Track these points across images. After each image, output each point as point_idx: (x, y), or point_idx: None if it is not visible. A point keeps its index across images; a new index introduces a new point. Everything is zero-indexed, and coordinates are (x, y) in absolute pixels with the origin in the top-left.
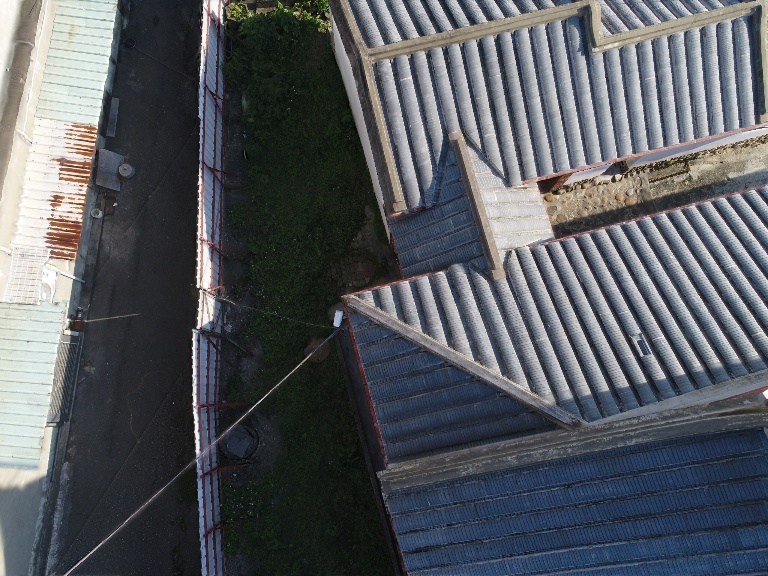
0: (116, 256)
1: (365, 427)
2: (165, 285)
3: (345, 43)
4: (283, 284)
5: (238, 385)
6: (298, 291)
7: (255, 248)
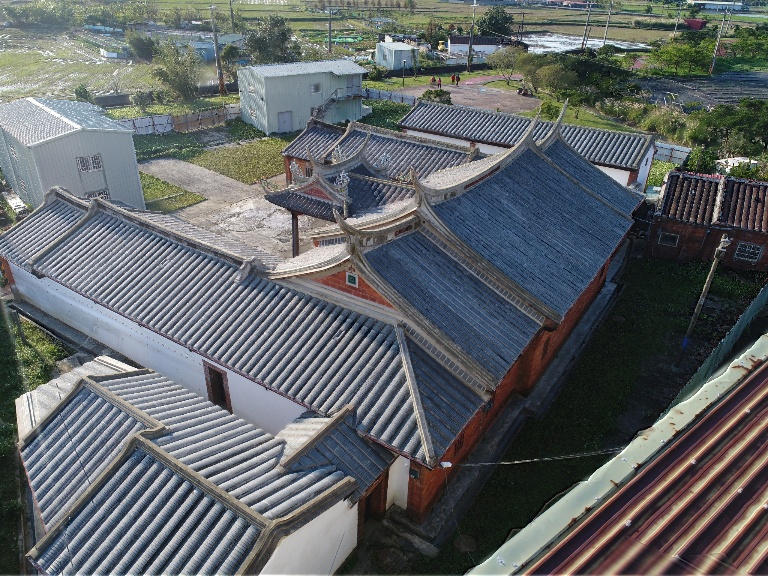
0: None
1: None
2: None
3: (261, 567)
4: None
5: None
6: (444, 575)
7: None
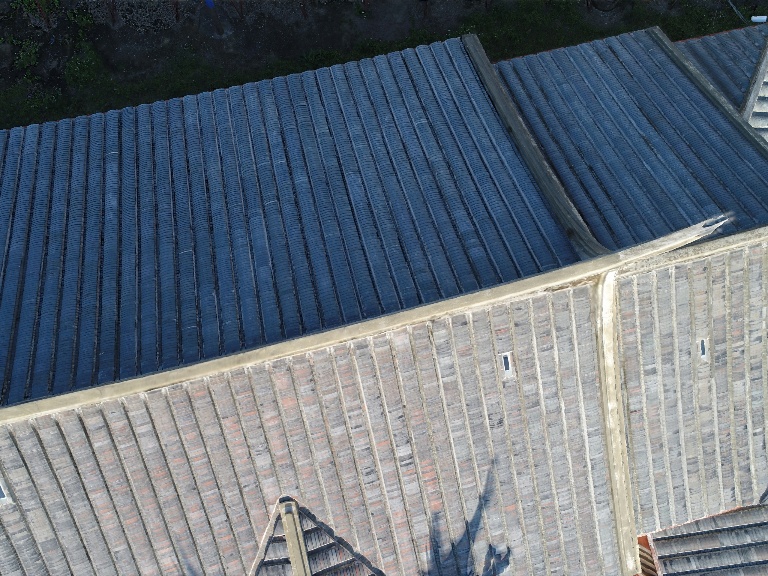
0: None
1: None
2: None
3: None
4: None
5: None
6: None
7: (760, 10)
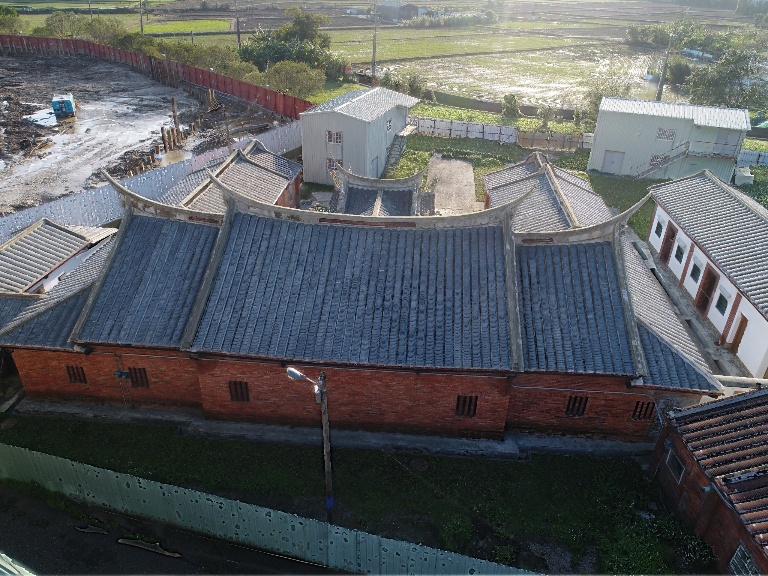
0: None
1: None
2: None
3: None
4: None
5: None
6: None
7: None
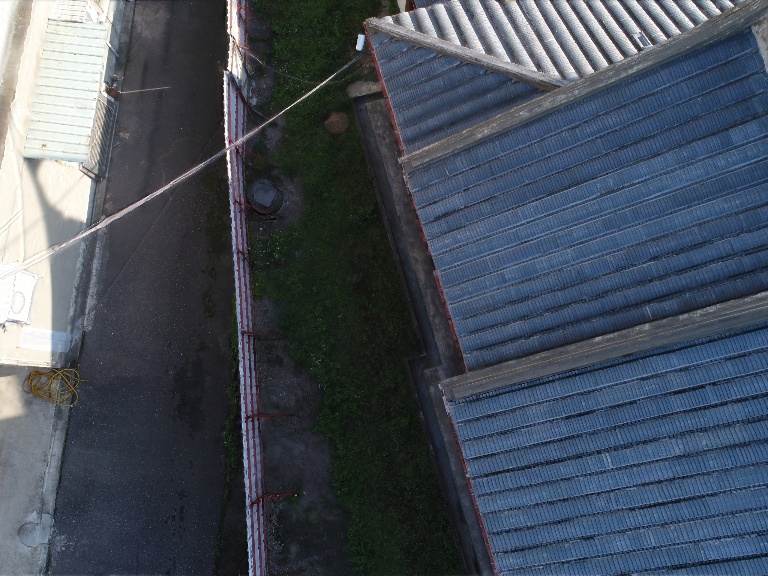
0: (148, 36)
1: (382, 194)
2: (194, 62)
3: None
4: (304, 62)
5: (263, 151)
6: (319, 65)
7: (278, 28)
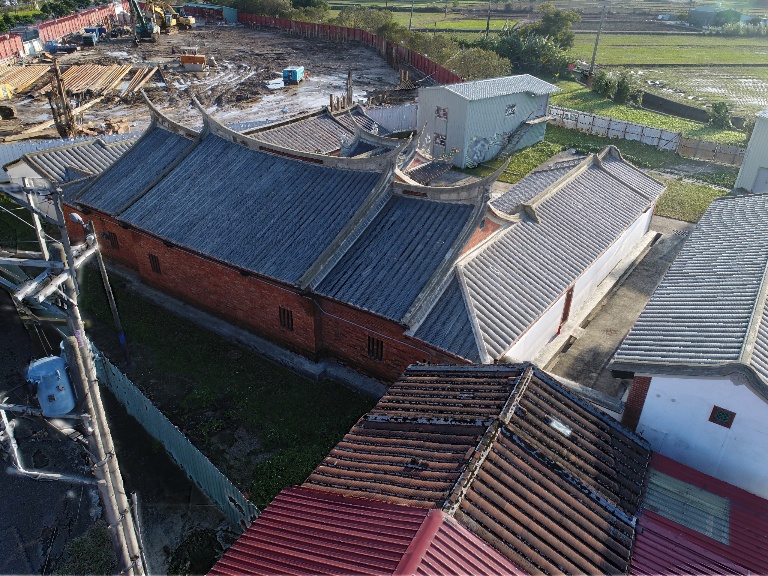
0: None
1: None
2: None
3: None
4: None
5: None
6: None
7: None
